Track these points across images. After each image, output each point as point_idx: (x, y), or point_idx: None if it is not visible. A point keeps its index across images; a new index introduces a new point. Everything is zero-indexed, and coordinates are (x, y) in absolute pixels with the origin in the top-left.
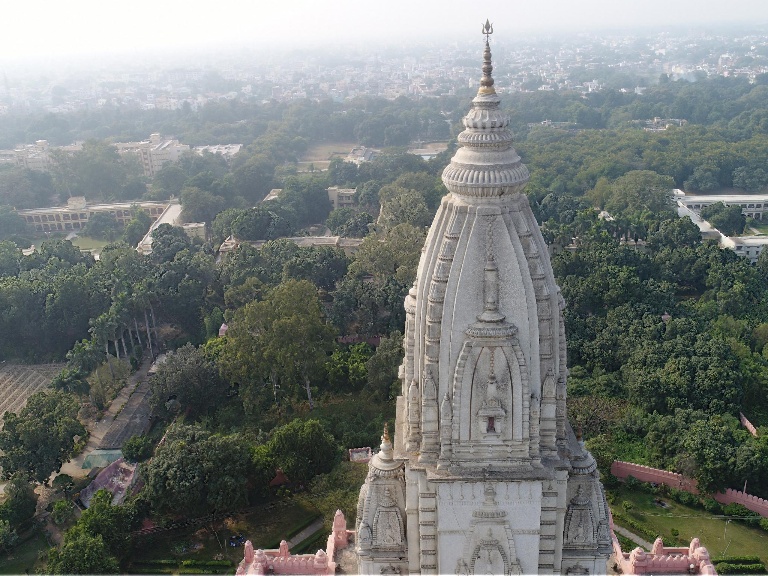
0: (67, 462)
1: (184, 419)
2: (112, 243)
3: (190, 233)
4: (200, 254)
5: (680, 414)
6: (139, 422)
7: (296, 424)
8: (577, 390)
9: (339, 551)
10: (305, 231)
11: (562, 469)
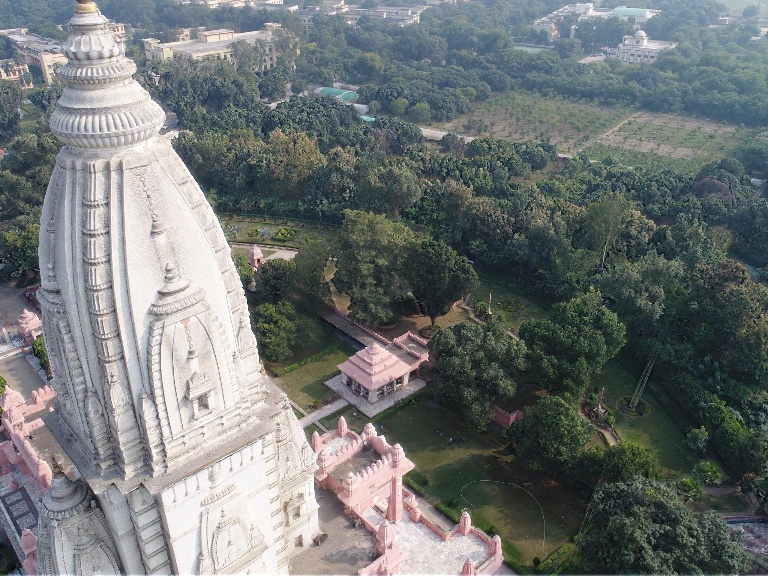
0: None
1: None
2: None
3: None
4: None
5: None
6: None
7: None
8: None
9: (376, 541)
10: None
11: None
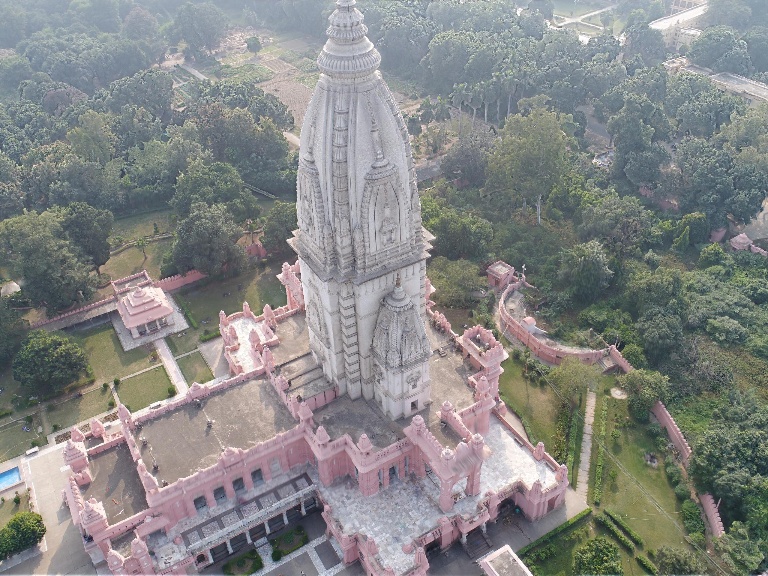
0: None
1: (465, 185)
2: (605, 27)
3: (686, 39)
4: (616, 62)
5: (762, 417)
6: (435, 171)
7: (471, 219)
8: (760, 349)
9: None
10: (767, 75)
11: (336, 281)
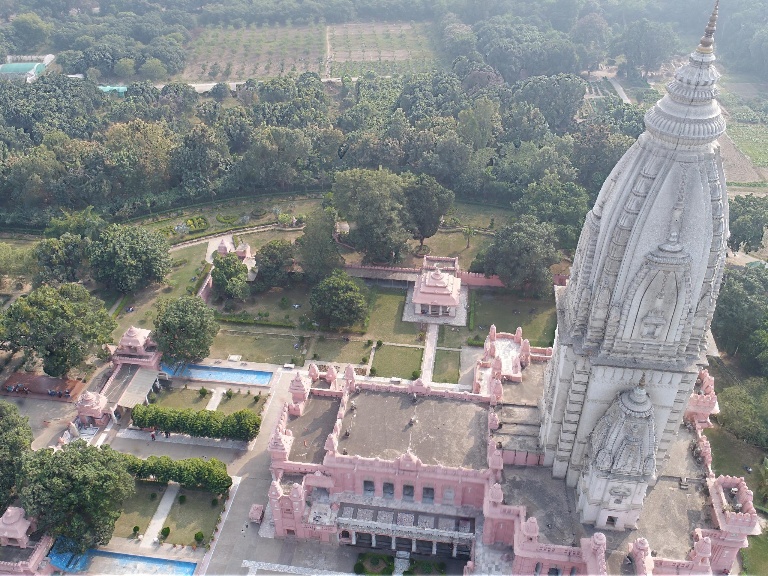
0: (760, 259)
1: None
2: None
3: None
4: None
5: None
6: None
7: None
8: None
9: None
10: None
11: None
